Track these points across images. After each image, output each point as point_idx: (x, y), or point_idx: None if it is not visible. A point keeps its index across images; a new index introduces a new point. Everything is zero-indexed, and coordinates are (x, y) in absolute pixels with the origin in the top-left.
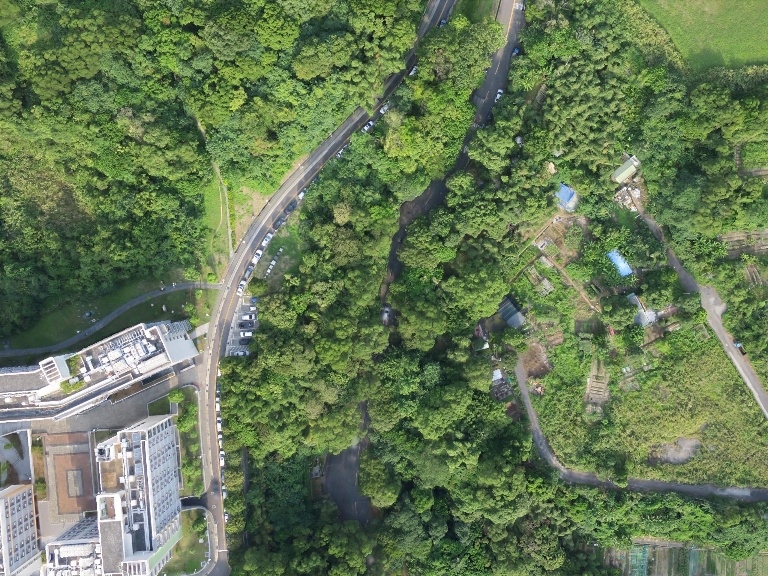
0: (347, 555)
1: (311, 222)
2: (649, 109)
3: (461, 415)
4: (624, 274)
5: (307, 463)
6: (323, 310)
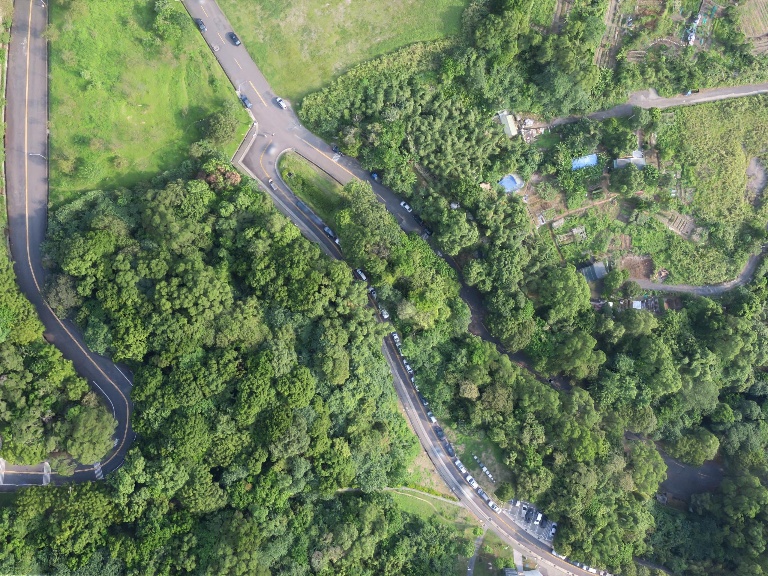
0: (760, 502)
1: (462, 420)
2: (475, 85)
3: (669, 352)
4: (595, 162)
5: (655, 505)
6: (544, 440)
